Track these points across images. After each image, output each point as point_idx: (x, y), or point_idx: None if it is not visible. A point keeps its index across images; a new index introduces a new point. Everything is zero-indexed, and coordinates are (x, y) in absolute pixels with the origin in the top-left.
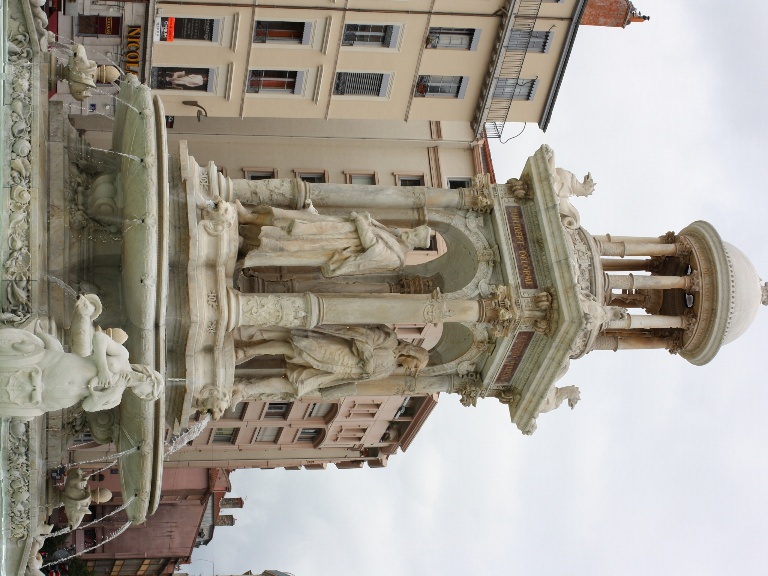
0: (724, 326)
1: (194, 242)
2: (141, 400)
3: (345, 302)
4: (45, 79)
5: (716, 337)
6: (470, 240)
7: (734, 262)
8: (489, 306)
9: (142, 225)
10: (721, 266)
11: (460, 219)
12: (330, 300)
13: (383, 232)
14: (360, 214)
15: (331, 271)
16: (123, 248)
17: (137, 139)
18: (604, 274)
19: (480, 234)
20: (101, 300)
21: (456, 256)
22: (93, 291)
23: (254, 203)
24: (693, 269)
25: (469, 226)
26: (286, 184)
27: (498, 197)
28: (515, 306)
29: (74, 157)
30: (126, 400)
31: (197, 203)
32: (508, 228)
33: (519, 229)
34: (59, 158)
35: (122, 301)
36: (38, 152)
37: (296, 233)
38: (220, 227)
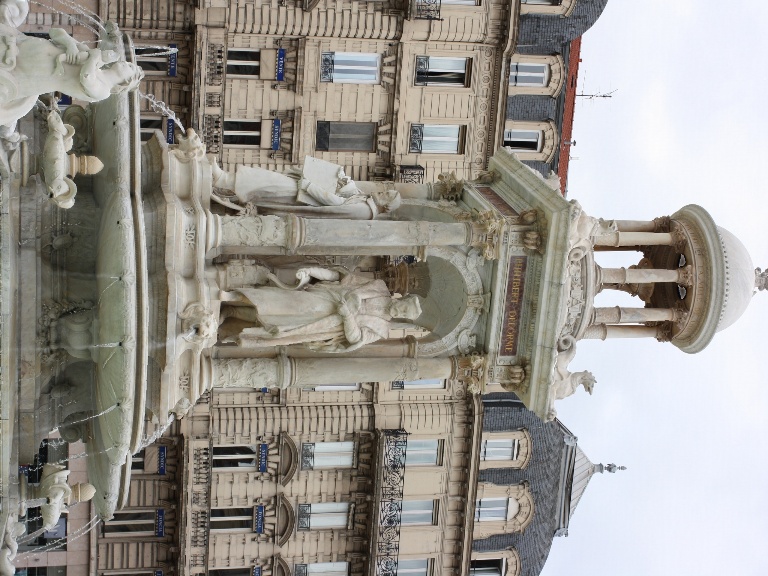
0: (694, 351)
1: (170, 367)
2: (106, 502)
3: (318, 374)
4: (16, 189)
5: (684, 349)
6: (465, 281)
7: (731, 299)
8: (461, 374)
9: (115, 447)
10: (713, 317)
11: (461, 256)
12: (303, 371)
13: (371, 318)
14: (351, 301)
15: (309, 348)
16: (96, 384)
17: (115, 369)
18: (592, 317)
19: (477, 276)
20: (72, 393)
21: (449, 270)
22: (64, 394)
23: None
24: (687, 300)
25: (468, 266)
26: (280, 233)
27: (507, 245)
28: (487, 375)
29: (48, 236)
30: (92, 470)
31: (178, 312)
32: (506, 284)
33: (518, 285)
34: (31, 301)
35: (93, 392)
36: (8, 373)
37: None
38: (199, 341)
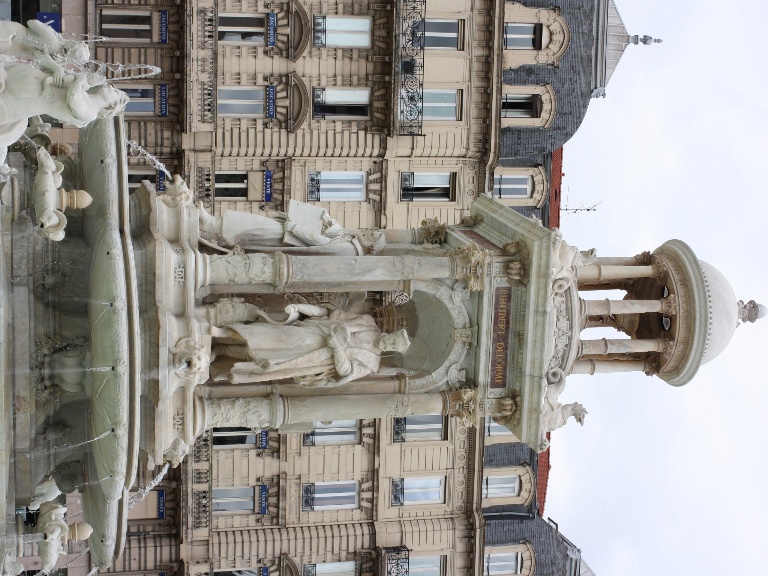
0: (682, 383)
1: (163, 402)
2: (103, 546)
3: (311, 411)
4: (7, 224)
5: (672, 382)
6: (452, 315)
7: (715, 327)
8: (453, 408)
9: None
10: (698, 345)
11: (446, 290)
12: (296, 409)
13: (360, 351)
14: (340, 333)
15: (301, 384)
16: None
17: (109, 395)
18: (579, 349)
19: (463, 309)
20: (67, 435)
21: (436, 307)
22: (59, 436)
23: (231, 284)
24: (672, 330)
25: (454, 300)
26: (268, 269)
27: (491, 276)
28: (478, 408)
29: (40, 275)
30: (89, 516)
31: (170, 346)
32: (492, 316)
33: (504, 316)
34: (24, 336)
35: (88, 433)
36: (3, 402)
37: (269, 371)
38: (191, 375)
